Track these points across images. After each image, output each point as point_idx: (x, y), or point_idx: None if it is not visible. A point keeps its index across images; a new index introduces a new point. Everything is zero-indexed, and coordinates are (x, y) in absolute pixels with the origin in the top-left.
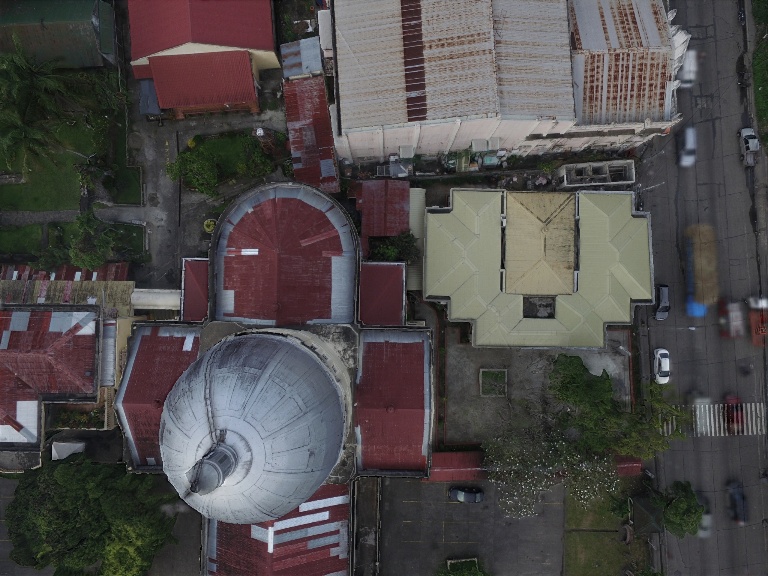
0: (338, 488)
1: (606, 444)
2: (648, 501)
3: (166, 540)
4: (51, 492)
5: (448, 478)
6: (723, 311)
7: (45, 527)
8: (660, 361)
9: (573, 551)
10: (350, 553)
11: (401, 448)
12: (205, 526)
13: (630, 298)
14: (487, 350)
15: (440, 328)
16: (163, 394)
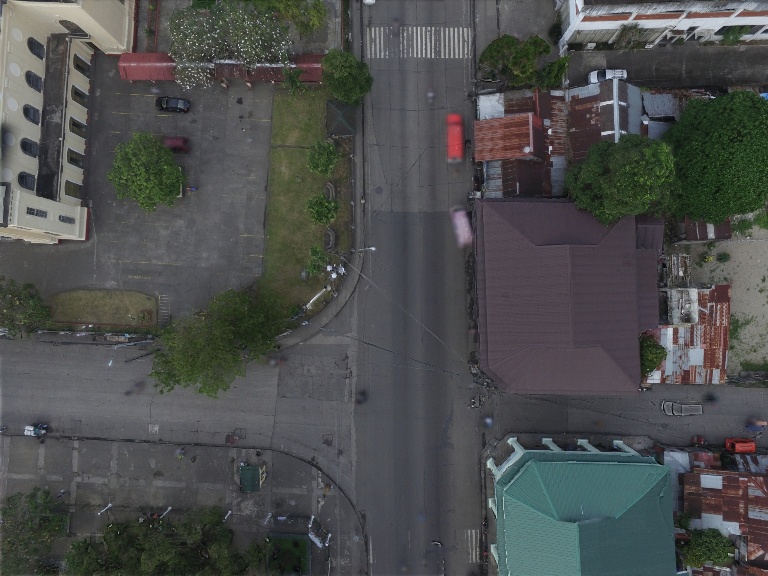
0: None
1: (268, 1)
2: None
3: None
4: None
5: (147, 76)
6: None
7: None
8: None
9: (278, 166)
10: None
11: None
12: None
13: None
14: None
15: None
16: None
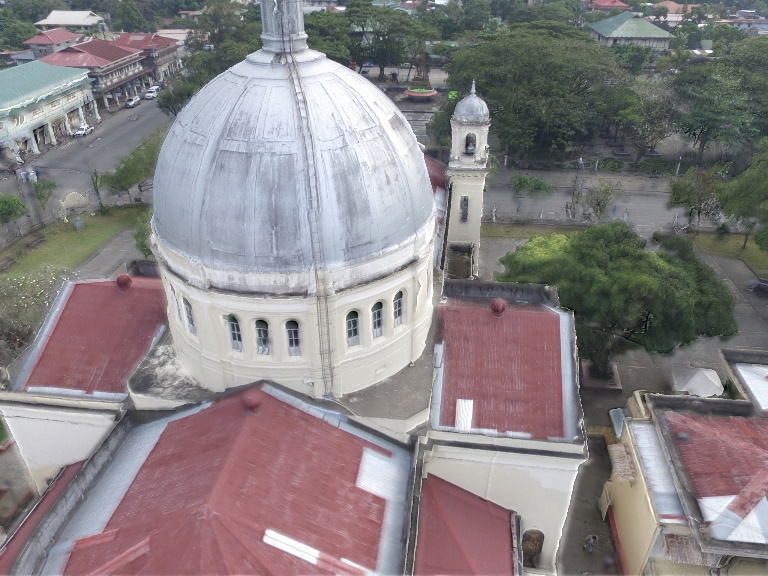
0: None
1: None
2: None
3: None
4: None
5: None
6: None
7: (656, 257)
8: None
9: None
10: None
11: None
12: None
13: None
14: None
15: None
16: (492, 325)
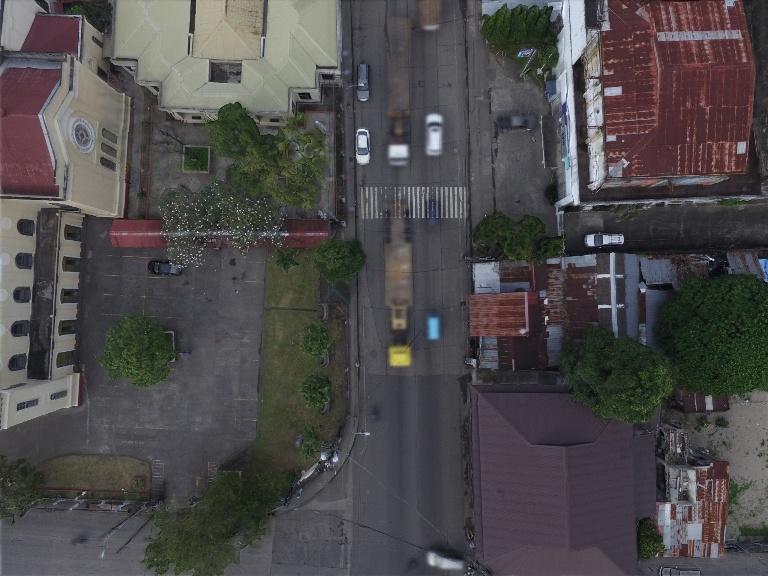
0: None
1: (260, 187)
2: None
3: None
4: None
5: (138, 244)
6: (429, 95)
7: None
8: (357, 138)
9: (271, 328)
10: None
11: (33, 167)
12: None
13: (316, 65)
14: (193, 128)
15: (146, 105)
16: None
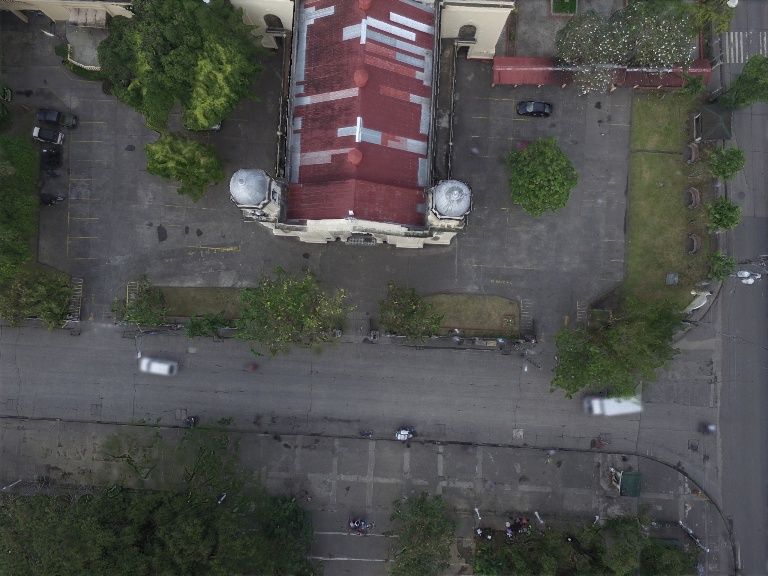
0: (424, 16)
1: (684, 7)
2: (717, 104)
3: (250, 92)
4: (148, 2)
5: (519, 81)
6: None
7: (140, 41)
8: None
9: (638, 170)
10: (436, 71)
11: None
12: (295, 45)
13: None
14: None
15: None
16: None
